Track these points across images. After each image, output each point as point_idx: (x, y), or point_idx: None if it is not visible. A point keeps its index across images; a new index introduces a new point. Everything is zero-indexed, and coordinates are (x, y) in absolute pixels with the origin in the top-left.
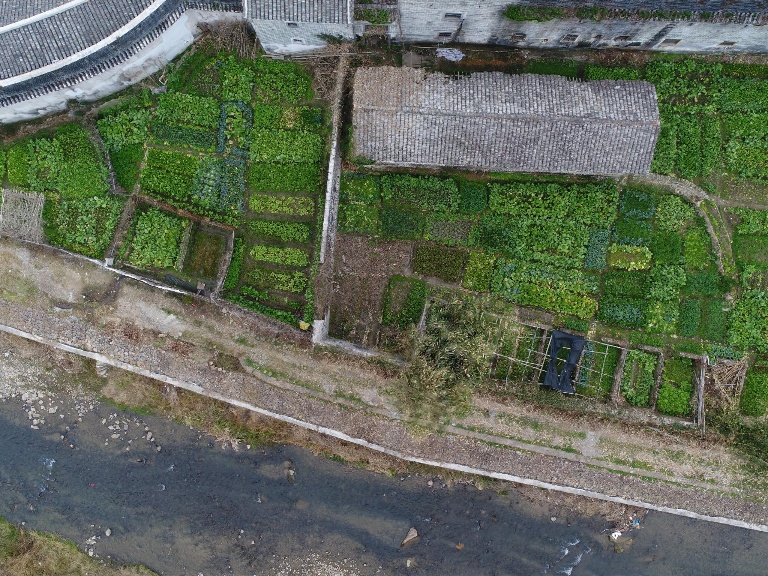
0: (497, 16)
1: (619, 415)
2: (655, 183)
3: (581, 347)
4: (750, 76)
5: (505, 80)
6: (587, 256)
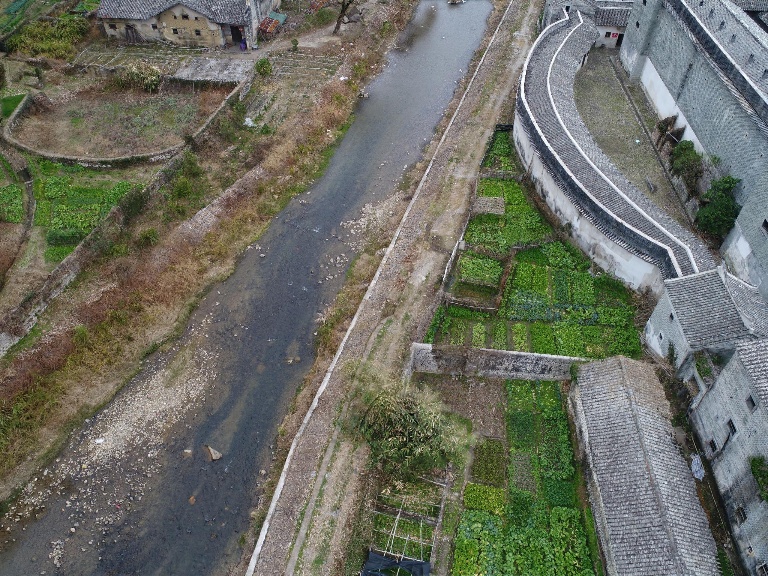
0: (749, 465)
1: None
2: None
3: None
4: None
5: (690, 488)
6: None
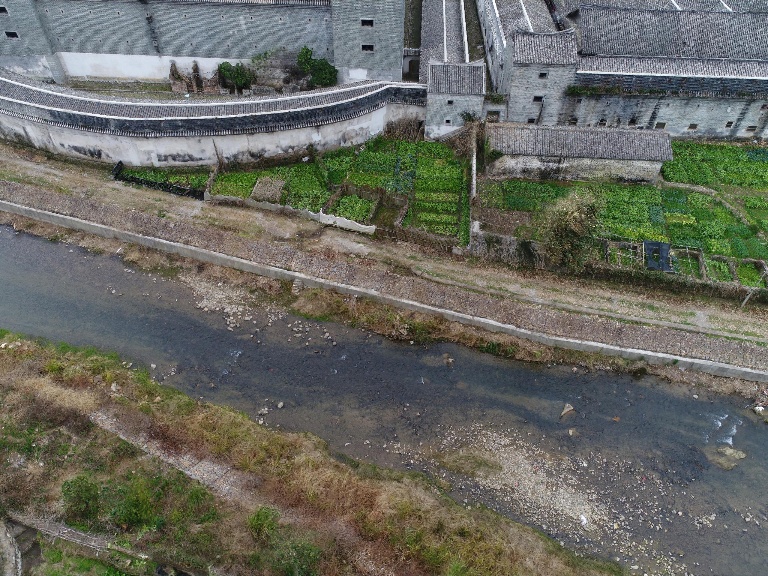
0: (562, 99)
1: (715, 283)
2: (680, 186)
3: (667, 247)
4: (714, 148)
5: None
6: (651, 217)
